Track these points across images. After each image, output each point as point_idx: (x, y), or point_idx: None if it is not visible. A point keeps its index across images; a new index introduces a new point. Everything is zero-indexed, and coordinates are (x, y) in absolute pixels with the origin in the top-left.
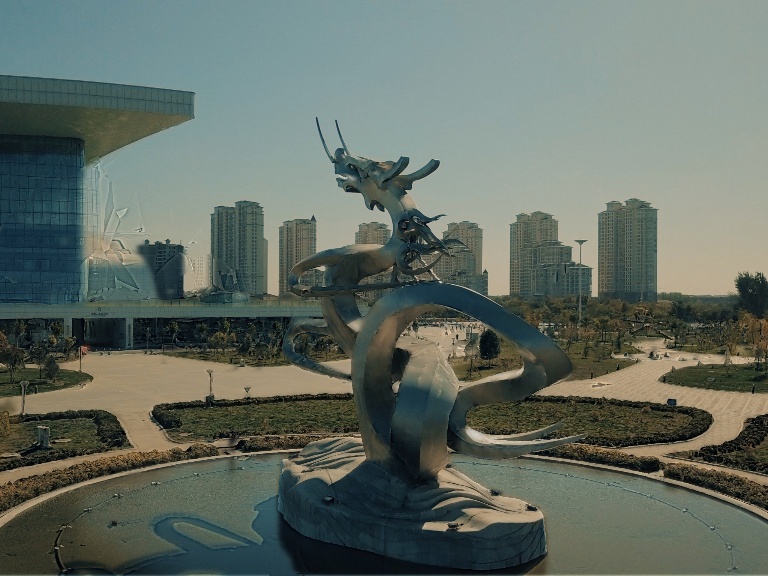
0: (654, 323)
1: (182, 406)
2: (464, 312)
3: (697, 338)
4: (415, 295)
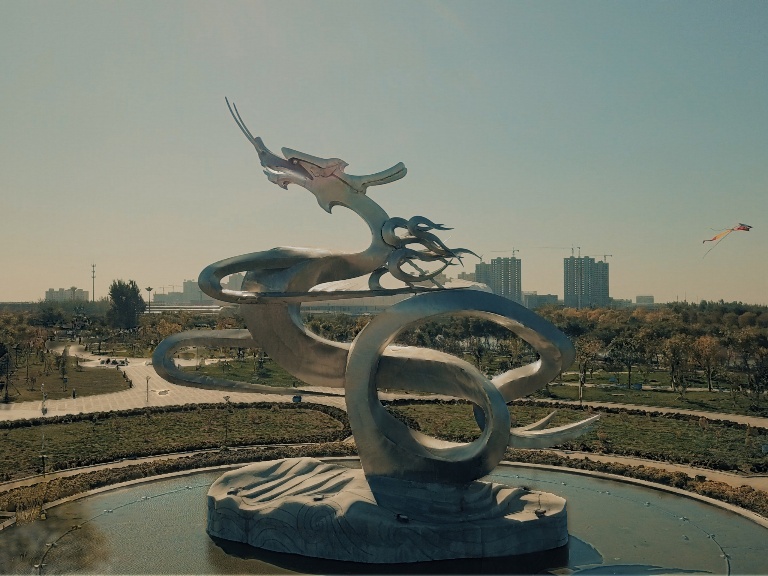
0: (89, 330)
1: None
2: (508, 317)
3: (117, 344)
4: (447, 302)
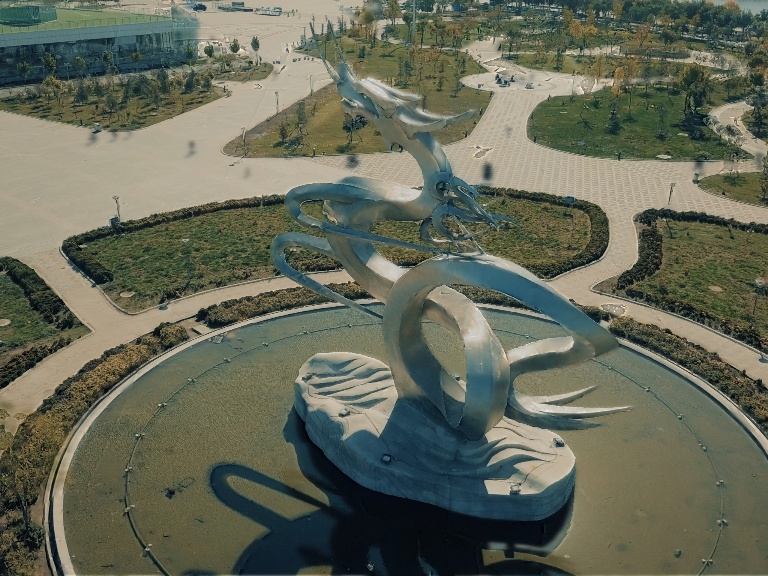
0: (495, 36)
1: (92, 238)
2: (525, 302)
3: (529, 45)
4: (467, 274)
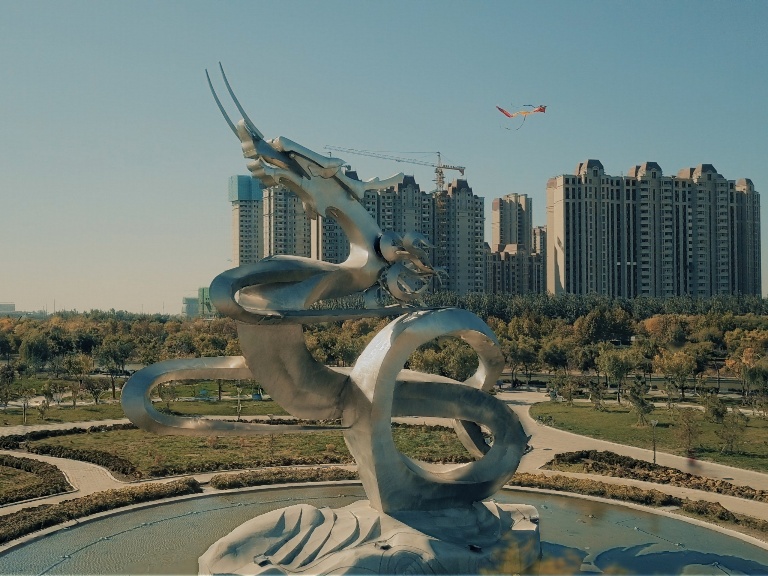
0: None
1: None
2: None
3: None
4: (451, 321)
